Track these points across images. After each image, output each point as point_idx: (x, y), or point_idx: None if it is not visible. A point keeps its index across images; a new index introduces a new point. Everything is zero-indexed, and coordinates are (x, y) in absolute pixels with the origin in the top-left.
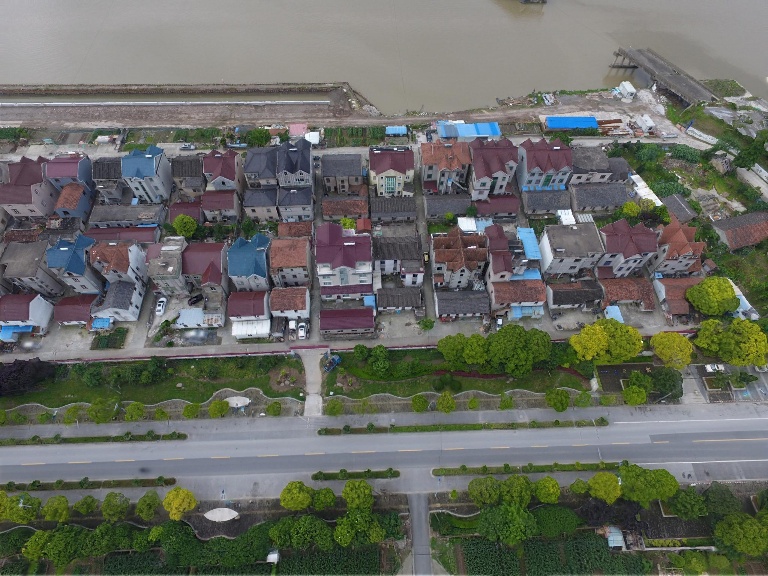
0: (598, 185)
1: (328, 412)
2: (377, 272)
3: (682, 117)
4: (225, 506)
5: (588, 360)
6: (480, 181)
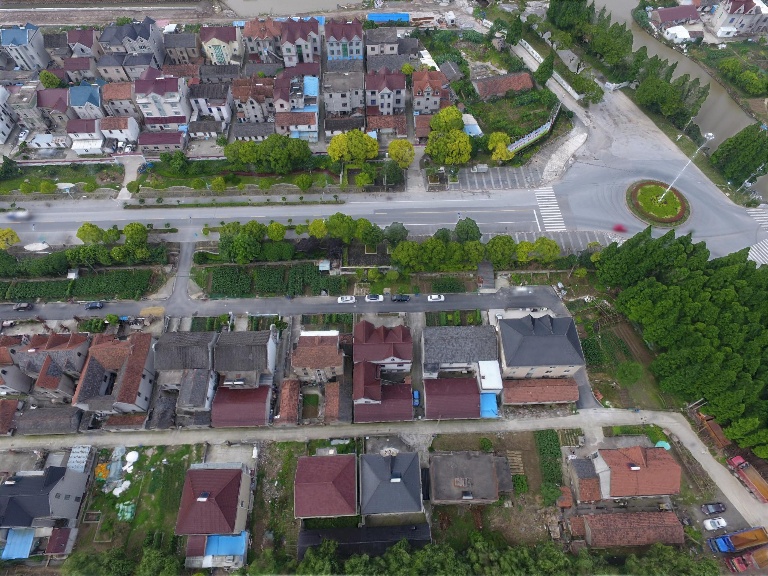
0: (388, 55)
1: (127, 188)
2: (195, 112)
3: (483, 14)
4: None
5: (336, 160)
6: (284, 47)
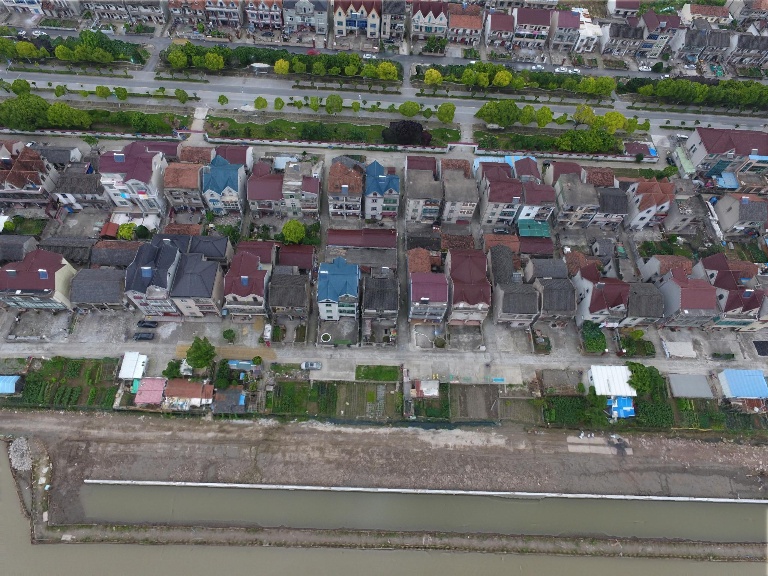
0: None
1: None
2: None
3: None
4: (262, 76)
5: None
6: None
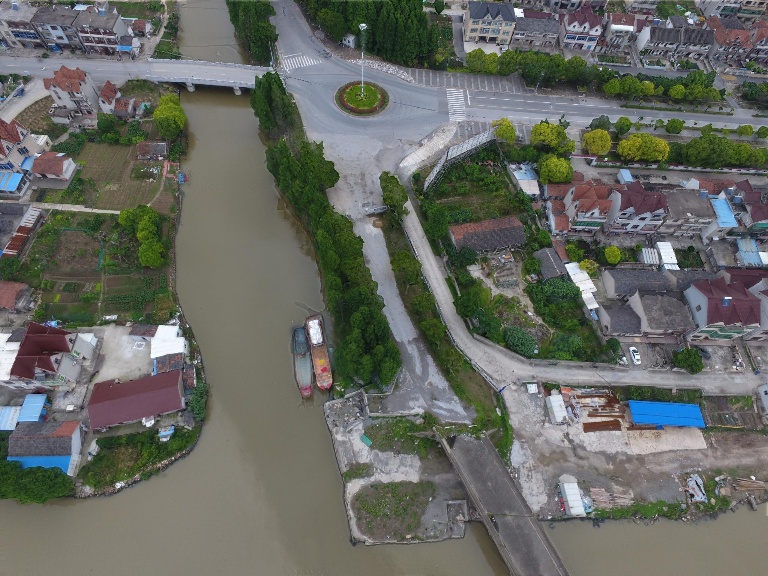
0: None
1: None
2: None
3: None
4: None
5: None
6: None
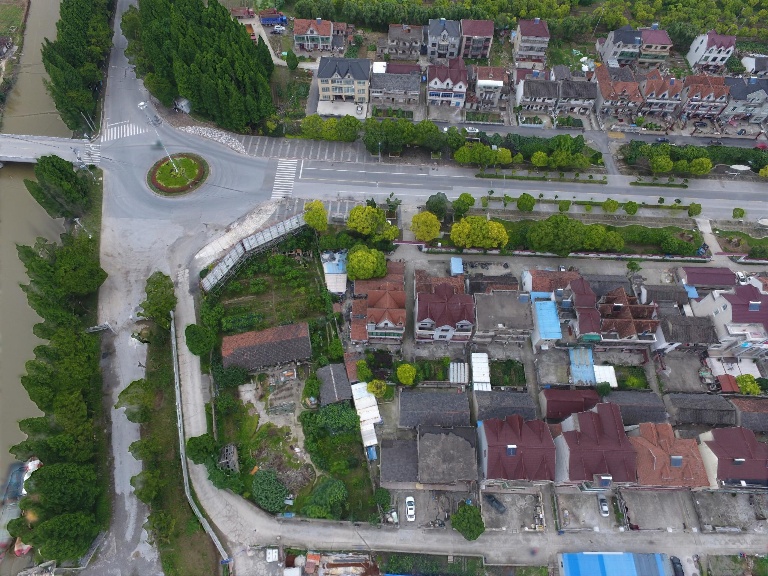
0: (435, 420)
1: None
2: None
3: None
4: (737, 178)
5: None
6: None
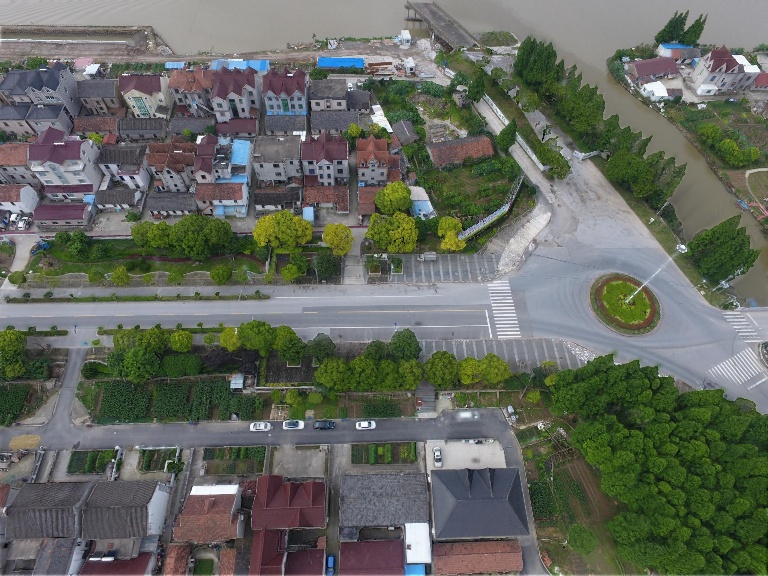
0: (335, 111)
1: (9, 280)
2: (107, 177)
3: None
4: None
5: (262, 246)
6: (215, 102)
